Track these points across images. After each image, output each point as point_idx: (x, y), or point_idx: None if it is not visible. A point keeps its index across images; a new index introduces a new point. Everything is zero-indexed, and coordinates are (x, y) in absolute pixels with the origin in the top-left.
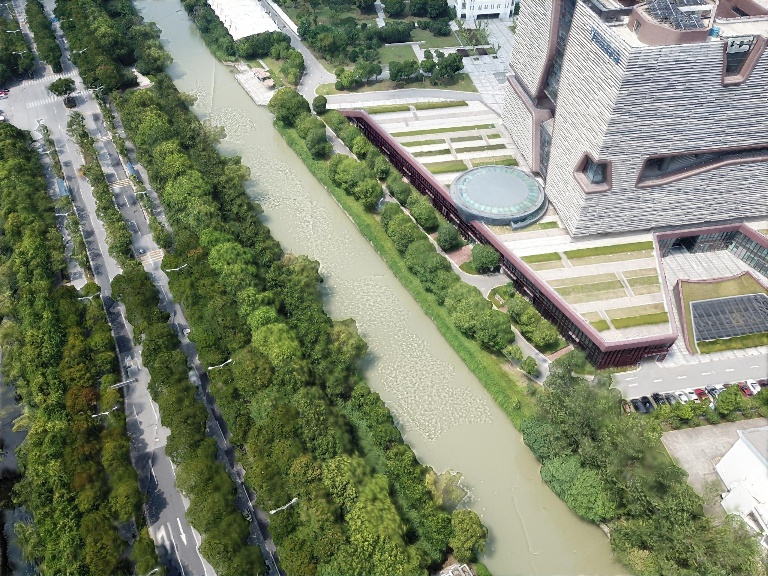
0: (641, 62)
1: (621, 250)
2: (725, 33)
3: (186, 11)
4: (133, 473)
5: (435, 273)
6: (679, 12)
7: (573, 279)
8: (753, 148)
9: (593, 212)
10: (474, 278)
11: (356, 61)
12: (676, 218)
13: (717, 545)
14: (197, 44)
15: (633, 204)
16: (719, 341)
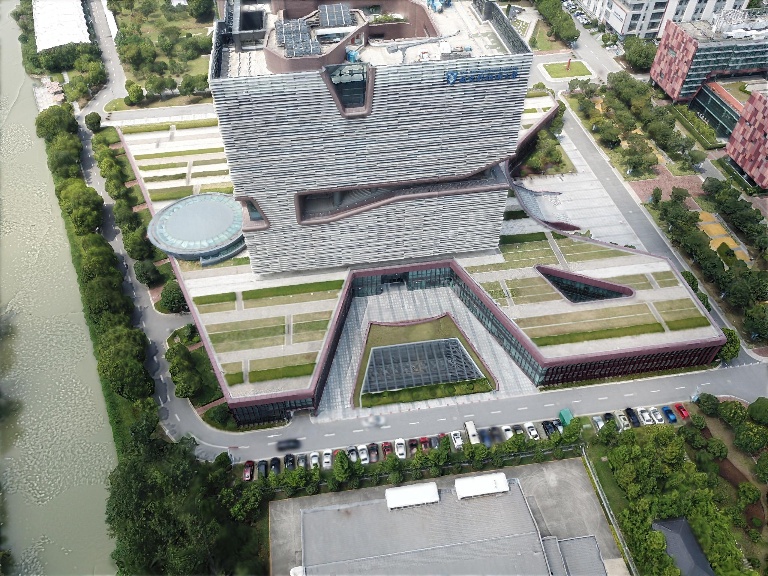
0: (229, 94)
1: (304, 290)
2: (369, 58)
3: (15, 20)
4: None
5: (100, 314)
6: (307, 36)
7: (236, 323)
8: (424, 182)
9: (263, 250)
10: (164, 317)
11: (163, 73)
12: (368, 255)
13: None
14: (21, 55)
15: (307, 241)
16: (384, 393)
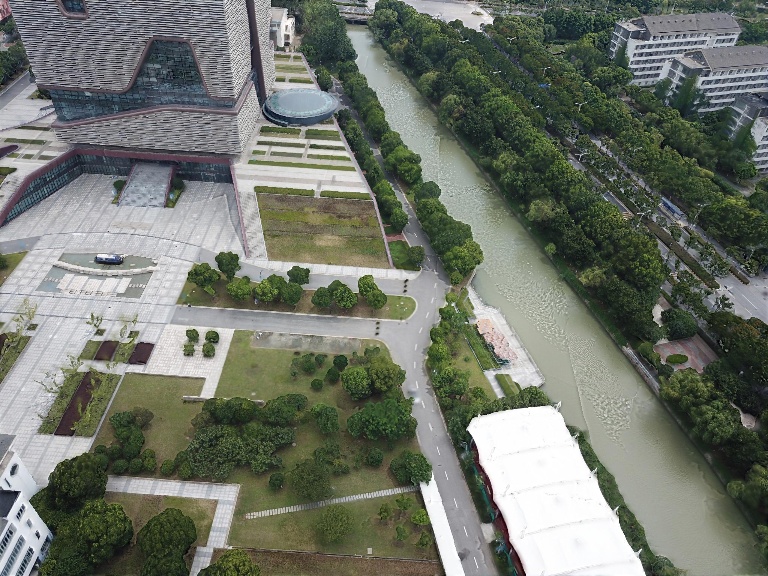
0: None
1: None
2: None
3: None
4: (526, 65)
5: None
6: None
7: (292, 72)
8: None
9: None
10: None
11: None
12: None
13: (324, 3)
14: None
15: None
16: None
